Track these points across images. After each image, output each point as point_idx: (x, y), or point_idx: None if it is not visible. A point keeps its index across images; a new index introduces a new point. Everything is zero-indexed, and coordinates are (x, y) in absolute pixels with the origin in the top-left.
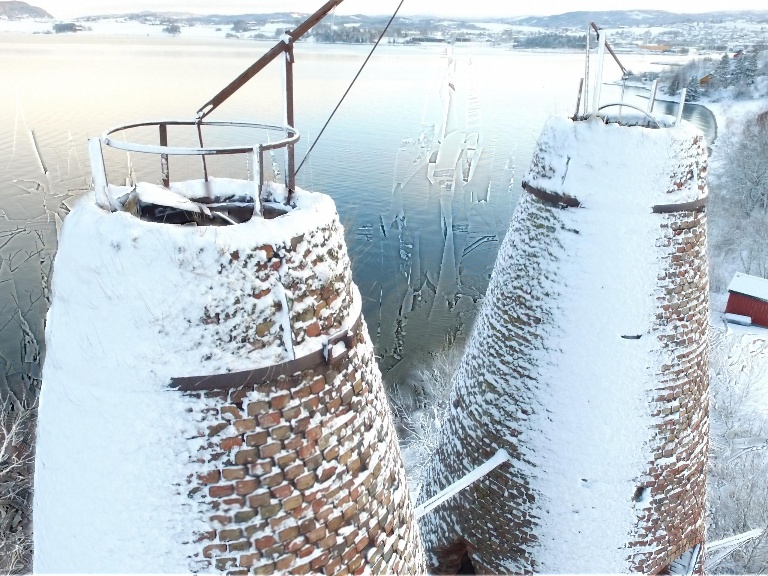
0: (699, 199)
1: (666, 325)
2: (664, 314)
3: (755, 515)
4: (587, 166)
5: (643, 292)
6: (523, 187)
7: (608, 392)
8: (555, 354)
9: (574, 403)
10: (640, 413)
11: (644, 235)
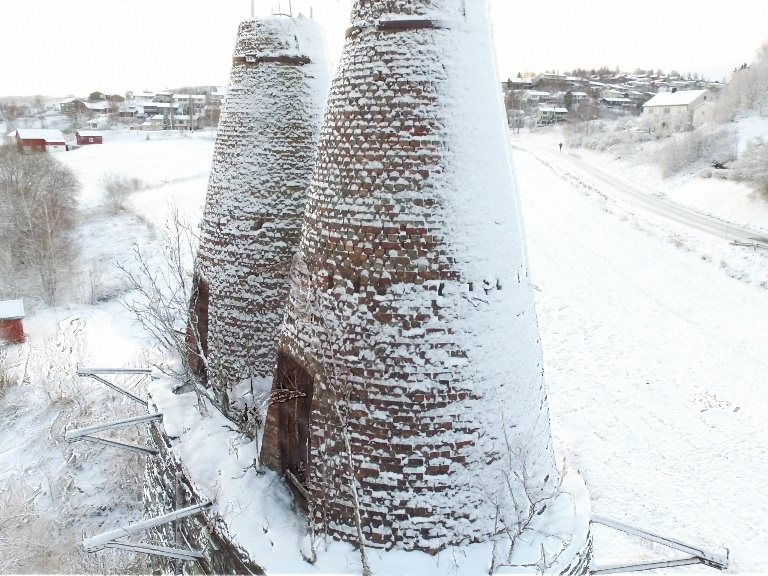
0: None
1: None
2: None
3: None
4: (308, 40)
5: None
6: (256, 62)
7: None
8: None
9: None
10: None
11: None
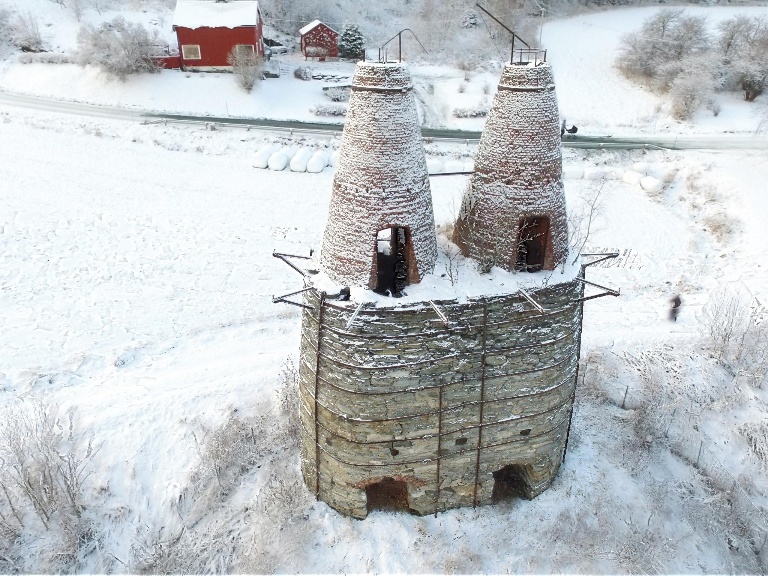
0: None
1: None
2: None
3: (5, 480)
4: None
5: None
6: None
7: None
8: None
9: None
10: None
11: None
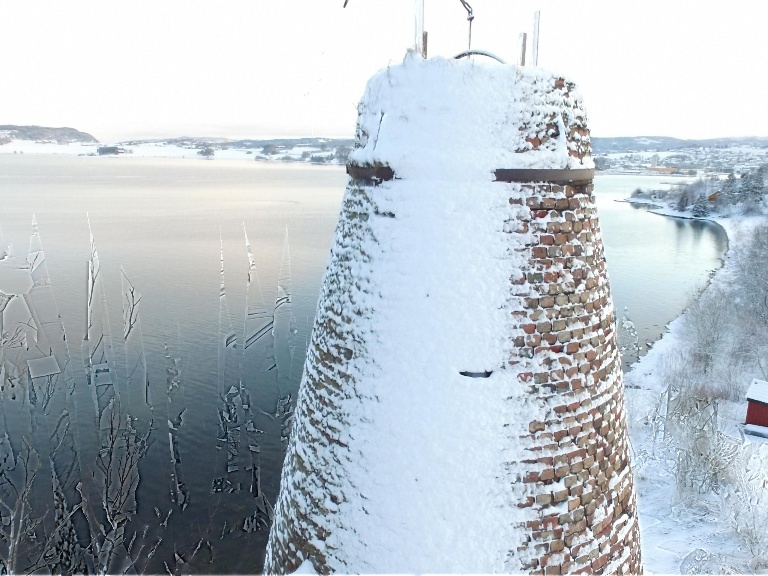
0: (572, 168)
1: (531, 357)
2: (526, 339)
3: None
4: (401, 119)
5: (488, 302)
6: None
7: (444, 464)
8: (369, 404)
9: (395, 483)
10: (498, 501)
11: (483, 213)
